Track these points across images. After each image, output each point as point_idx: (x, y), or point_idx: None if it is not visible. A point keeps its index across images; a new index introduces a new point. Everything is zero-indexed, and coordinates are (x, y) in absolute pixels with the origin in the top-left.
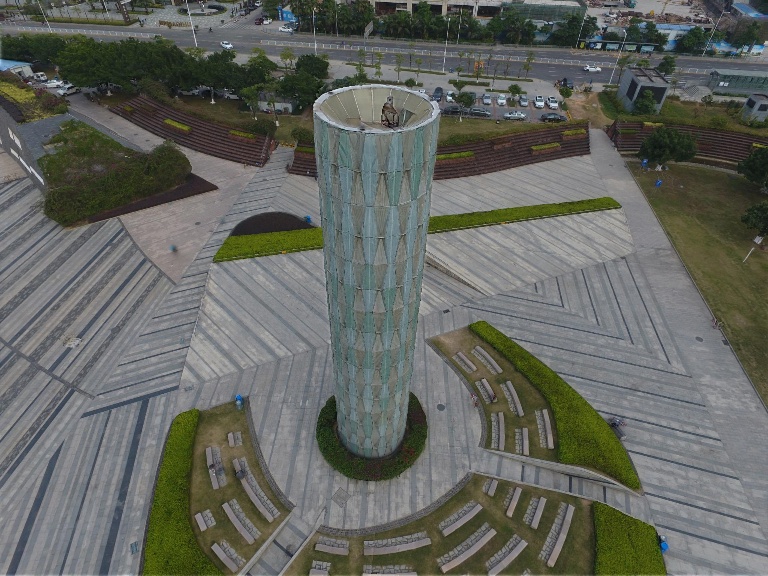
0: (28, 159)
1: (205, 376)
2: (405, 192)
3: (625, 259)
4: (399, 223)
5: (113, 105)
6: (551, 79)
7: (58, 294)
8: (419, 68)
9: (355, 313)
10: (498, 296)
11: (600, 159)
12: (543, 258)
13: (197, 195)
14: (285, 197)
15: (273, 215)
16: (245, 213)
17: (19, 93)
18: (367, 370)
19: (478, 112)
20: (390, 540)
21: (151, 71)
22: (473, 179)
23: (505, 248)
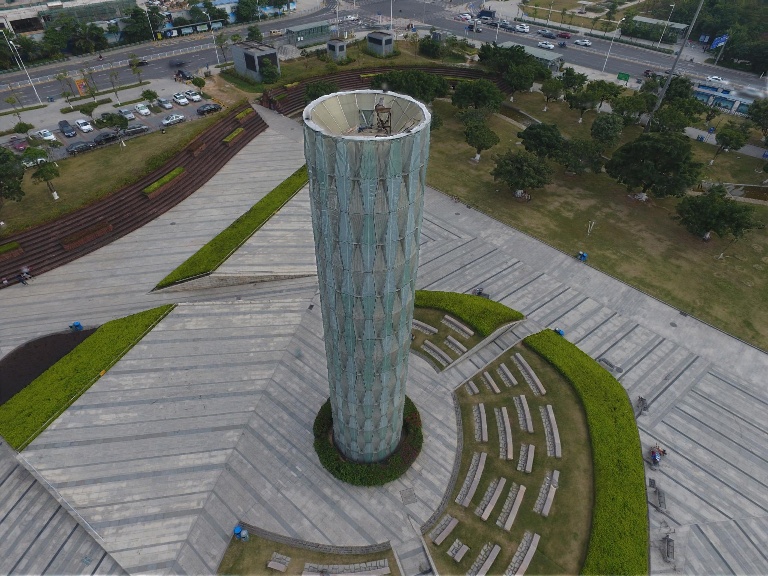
0: None
1: (169, 556)
2: None
3: None
4: None
5: None
6: (166, 75)
7: None
8: (15, 108)
9: (392, 318)
10: None
11: (280, 127)
12: None
13: None
14: (8, 325)
15: (22, 352)
16: None
17: None
18: None
19: (134, 130)
20: (466, 481)
21: None
22: (202, 192)
23: (297, 230)
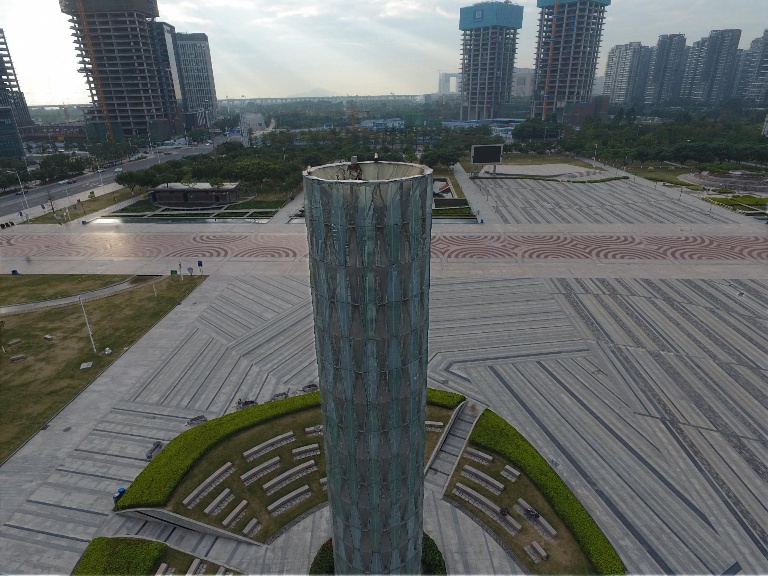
0: None
1: None
2: None
3: None
4: None
5: None
6: None
7: None
8: None
9: None
10: None
11: None
12: None
13: None
14: None
15: None
16: None
17: None
18: None
19: None
20: None
21: None
22: None
23: None
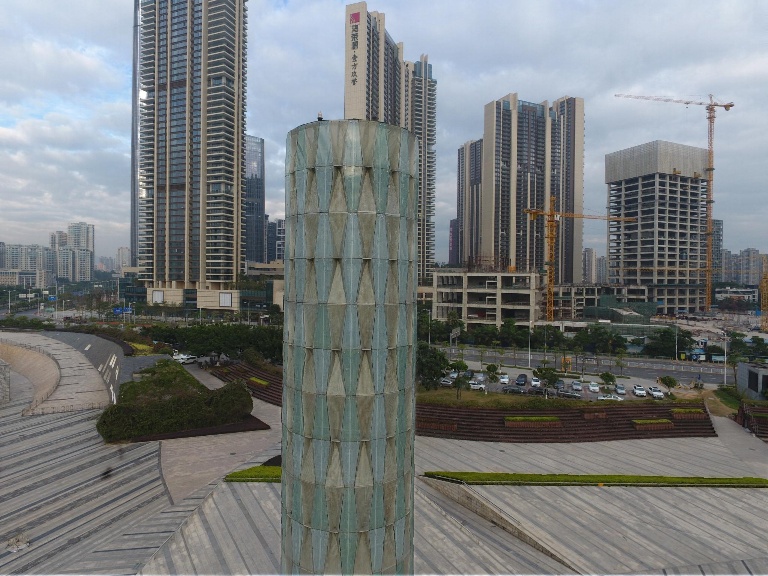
0: (116, 386)
1: None
2: (367, 199)
3: None
4: (360, 239)
5: (215, 370)
6: (651, 377)
7: (49, 497)
8: None
9: (304, 399)
10: None
11: (734, 442)
12: (670, 536)
13: (247, 432)
14: None
15: None
16: None
17: (144, 346)
18: (318, 534)
19: (566, 394)
20: None
21: (256, 344)
22: (560, 446)
23: (607, 515)
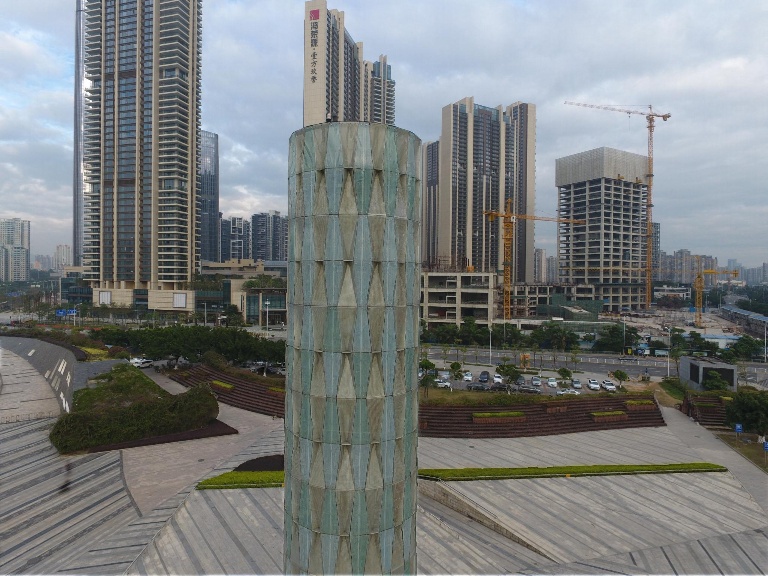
0: (68, 394)
1: None
2: (377, 201)
3: (762, 532)
4: (371, 242)
5: (174, 374)
6: (603, 371)
7: (1, 515)
8: None
9: (312, 403)
10: (575, 564)
11: (681, 430)
12: (634, 521)
13: (214, 437)
14: None
15: None
16: (257, 454)
17: (97, 351)
18: (327, 538)
19: (527, 389)
20: None
21: (217, 346)
22: (526, 440)
23: (575, 504)
